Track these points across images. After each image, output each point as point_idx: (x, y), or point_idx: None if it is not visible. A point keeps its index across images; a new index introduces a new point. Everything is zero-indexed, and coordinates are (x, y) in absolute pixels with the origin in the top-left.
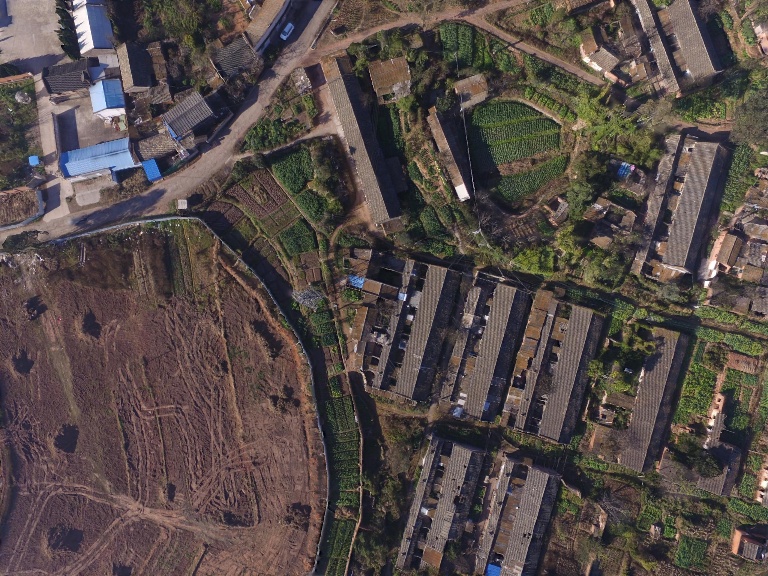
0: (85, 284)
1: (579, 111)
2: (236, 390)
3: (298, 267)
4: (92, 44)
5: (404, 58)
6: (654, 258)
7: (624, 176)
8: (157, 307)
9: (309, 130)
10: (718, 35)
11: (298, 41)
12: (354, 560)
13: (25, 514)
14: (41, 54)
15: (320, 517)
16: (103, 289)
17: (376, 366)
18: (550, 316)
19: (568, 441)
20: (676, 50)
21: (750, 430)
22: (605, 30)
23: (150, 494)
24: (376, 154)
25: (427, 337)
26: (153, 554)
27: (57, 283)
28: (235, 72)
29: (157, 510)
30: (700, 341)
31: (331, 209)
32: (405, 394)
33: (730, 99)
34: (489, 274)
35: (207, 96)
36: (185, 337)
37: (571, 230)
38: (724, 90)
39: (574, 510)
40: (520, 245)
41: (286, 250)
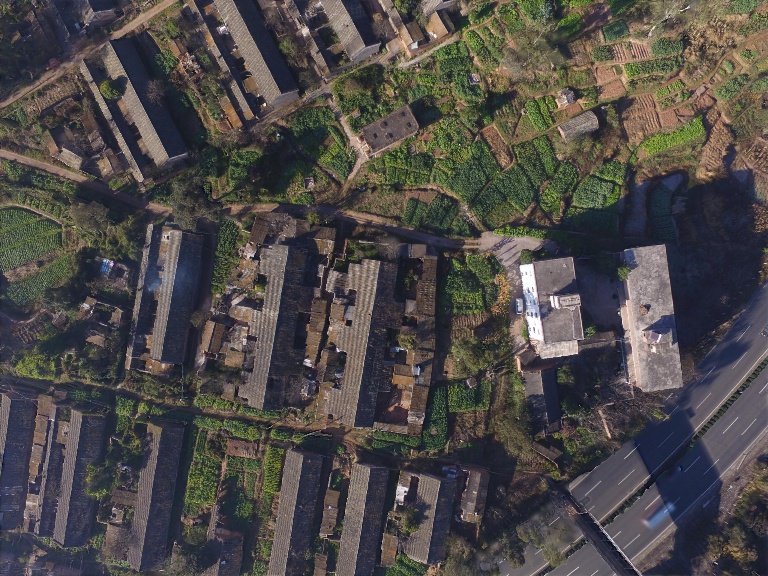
0: None
1: None
2: None
3: None
4: None
5: None
6: (145, 352)
7: (105, 273)
8: None
9: None
10: (191, 114)
11: None
12: None
13: None
14: None
15: None
16: None
17: None
18: (53, 421)
19: (80, 543)
20: (139, 139)
21: (256, 516)
22: (70, 128)
23: None
24: None
25: None
26: None
27: None
28: None
29: None
30: (201, 430)
31: None
32: None
33: (211, 178)
34: None
35: None
36: None
37: (41, 338)
38: (200, 170)
39: None
40: None
41: None
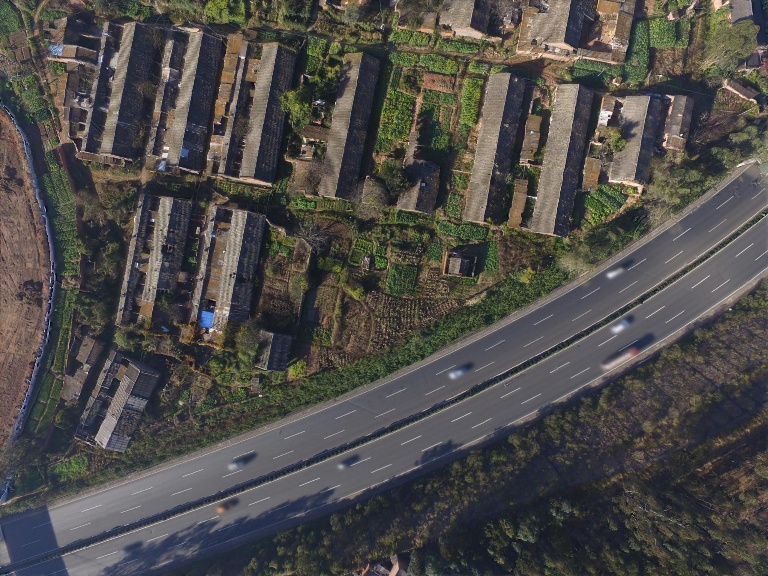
0: None
1: None
2: None
3: (7, 48)
4: None
5: None
6: None
7: None
8: None
9: None
10: None
11: None
12: (76, 322)
13: None
14: None
15: (49, 289)
16: None
17: (83, 131)
18: (242, 59)
19: (269, 180)
20: None
21: (452, 149)
22: None
23: None
24: None
25: (122, 92)
26: None
27: None
28: None
29: None
30: (396, 67)
31: None
32: (107, 151)
33: None
34: (184, 28)
35: None
36: None
37: None
38: None
39: (285, 252)
40: None
41: None
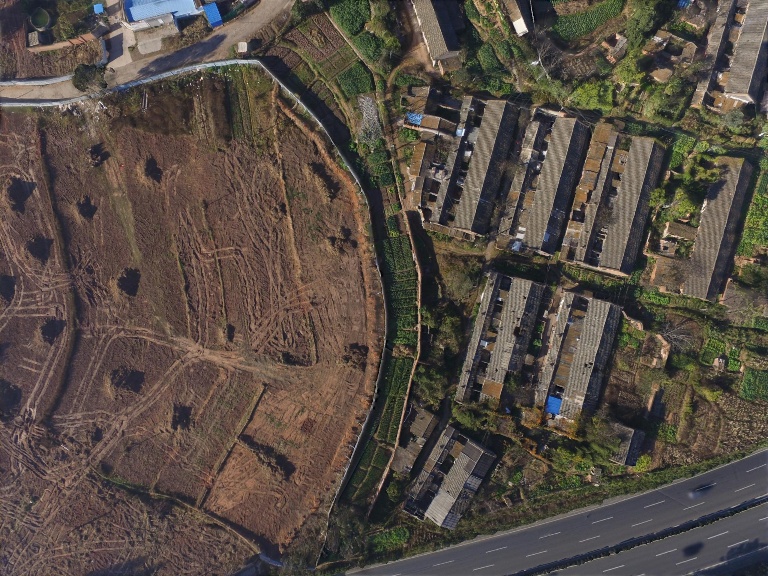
0: (147, 130)
1: None
2: (294, 231)
3: (355, 108)
4: None
5: None
6: (715, 89)
7: (684, 7)
8: (217, 151)
9: None
10: None
11: None
12: (413, 394)
13: (88, 356)
14: None
15: (378, 356)
16: (164, 135)
17: (434, 202)
18: (610, 148)
19: (629, 272)
20: None
21: None
22: None
23: (210, 336)
24: None
25: (486, 169)
26: (213, 394)
27: (120, 130)
28: None
29: (216, 351)
30: (763, 173)
31: (389, 46)
32: (464, 227)
33: None
34: (547, 110)
35: None
36: (244, 180)
37: (632, 55)
38: None
39: (635, 344)
40: (579, 77)
41: (344, 92)
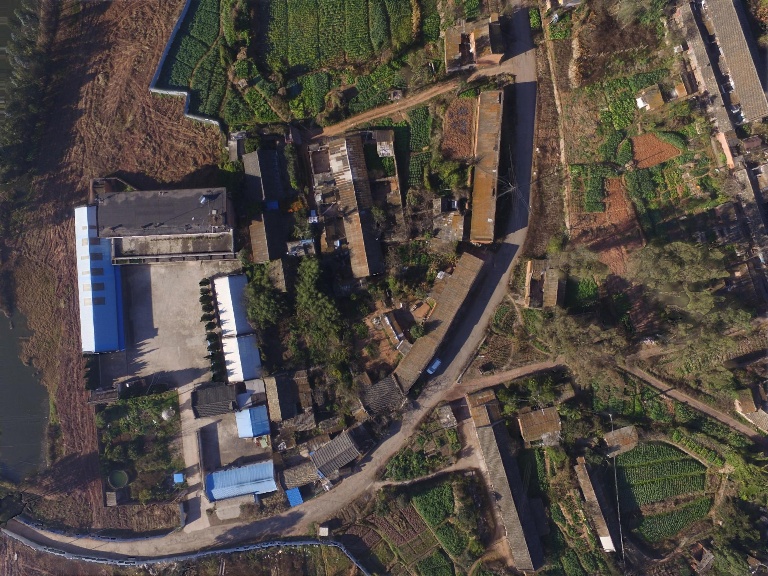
0: None
1: (728, 458)
2: None
3: None
4: (242, 376)
5: (555, 409)
6: None
7: None
8: None
9: (451, 463)
10: None
11: (444, 374)
12: None
13: None
14: (186, 367)
15: None
16: None
17: None
18: None
19: None
20: None
21: None
22: (763, 387)
23: None
24: (522, 502)
25: None
26: None
27: None
28: (382, 409)
29: None
30: None
31: (474, 552)
32: None
33: None
34: None
35: (352, 428)
36: None
37: None
38: None
39: None
40: None
41: None
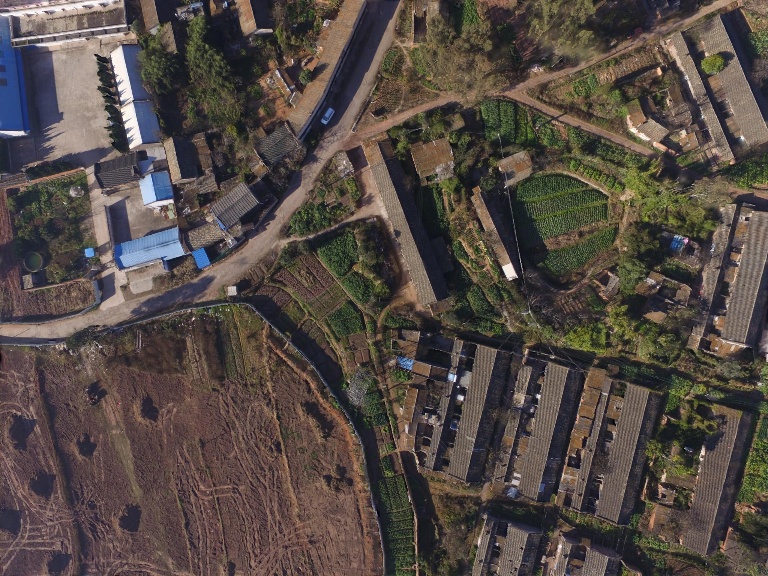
0: (142, 370)
1: (627, 182)
2: (290, 470)
3: (347, 349)
4: (140, 140)
5: (446, 139)
6: (712, 332)
7: (677, 249)
8: (211, 390)
9: (353, 212)
10: None
11: (339, 124)
12: None
13: None
14: (92, 148)
15: None
16: (159, 374)
17: (428, 447)
18: (604, 394)
19: (627, 522)
20: (729, 117)
21: None
22: (653, 99)
23: (211, 571)
24: (421, 237)
25: (479, 419)
26: None
27: (115, 369)
28: (279, 160)
29: None
30: (763, 416)
31: (378, 293)
32: (458, 476)
33: None
34: (539, 352)
35: (252, 184)
36: (239, 419)
37: (624, 310)
38: None
39: None
40: (571, 324)
41: (334, 332)
